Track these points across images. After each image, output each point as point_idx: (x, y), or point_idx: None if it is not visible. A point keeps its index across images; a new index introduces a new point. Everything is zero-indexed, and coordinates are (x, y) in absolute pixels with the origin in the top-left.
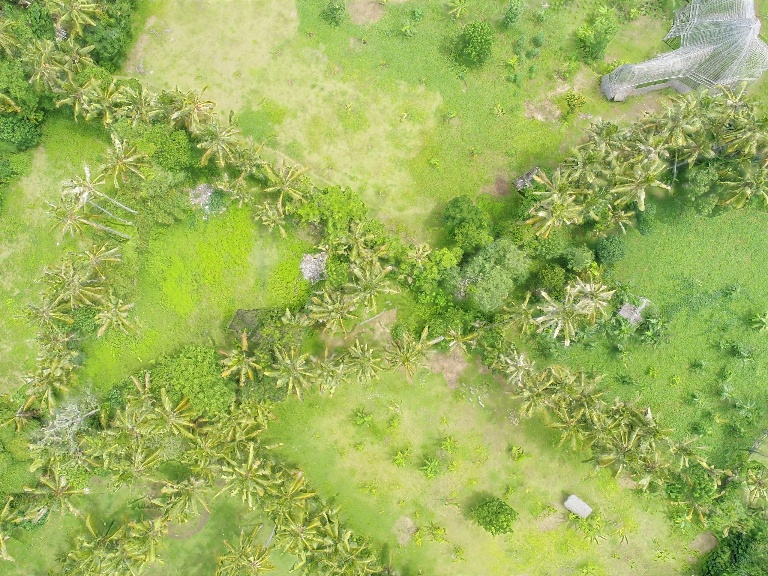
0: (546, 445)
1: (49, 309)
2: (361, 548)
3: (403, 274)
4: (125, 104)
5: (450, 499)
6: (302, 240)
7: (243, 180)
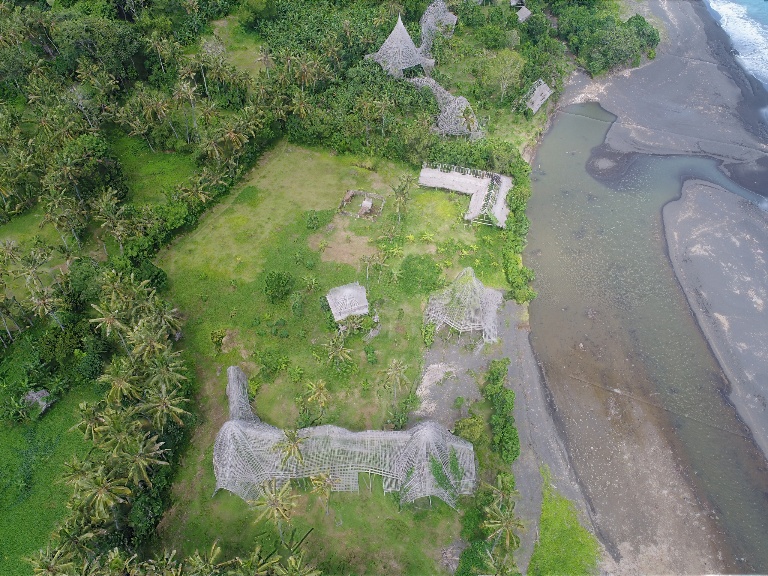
0: None
1: None
2: None
3: None
4: None
5: None
6: None
7: (204, 176)
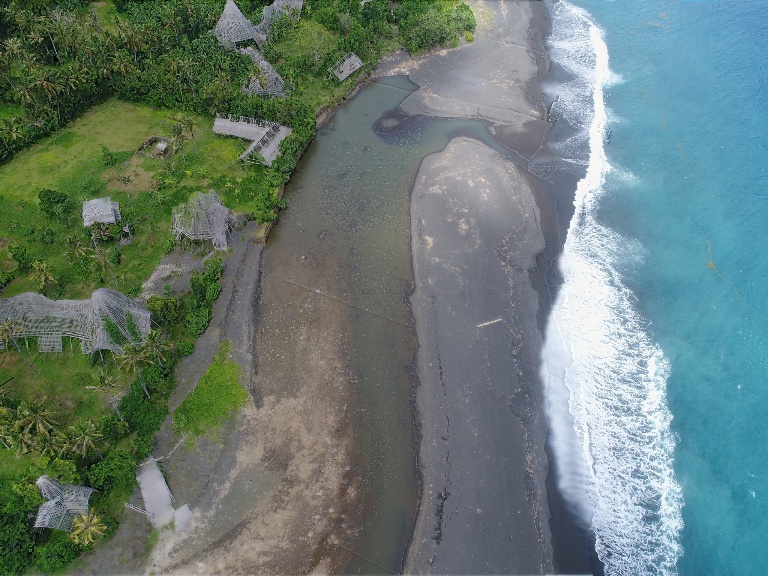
0: None
1: None
2: None
3: None
4: None
5: None
6: None
7: None
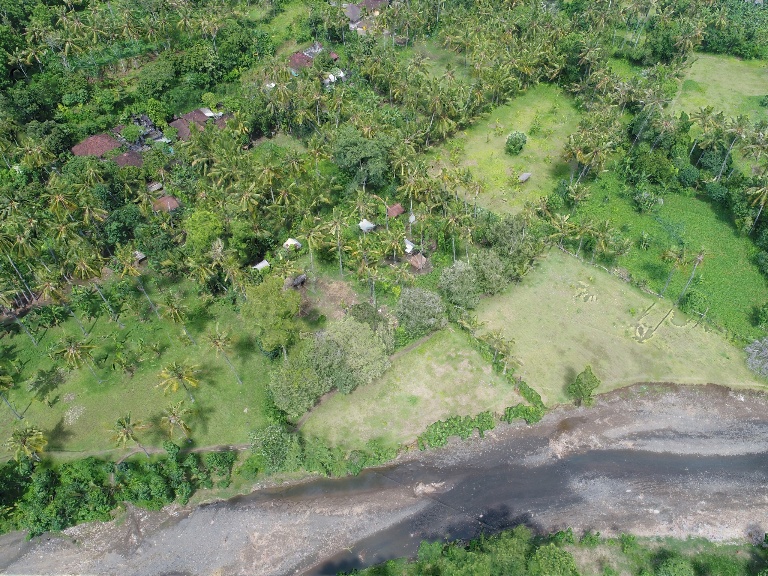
0: (556, 172)
1: None
2: None
3: None
4: None
5: None
6: None
7: None
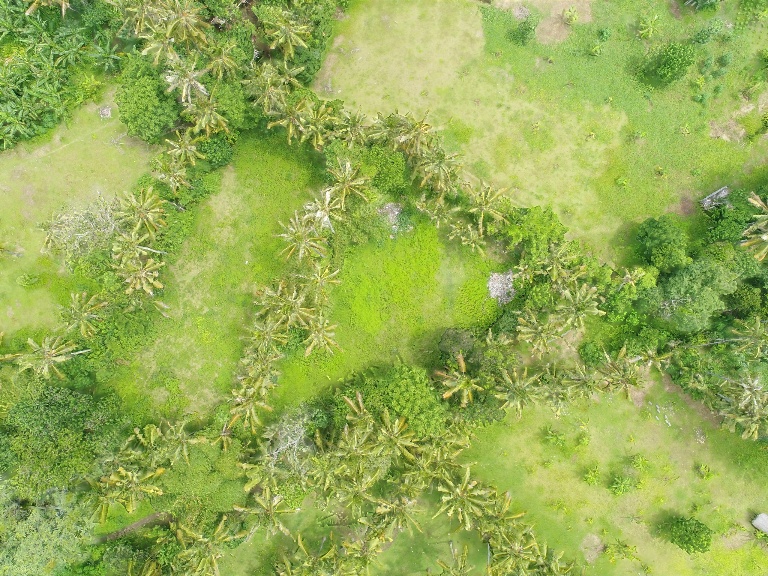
0: (732, 463)
1: (271, 330)
2: (570, 567)
3: (595, 293)
4: (341, 126)
5: (637, 517)
6: (489, 259)
7: (442, 200)
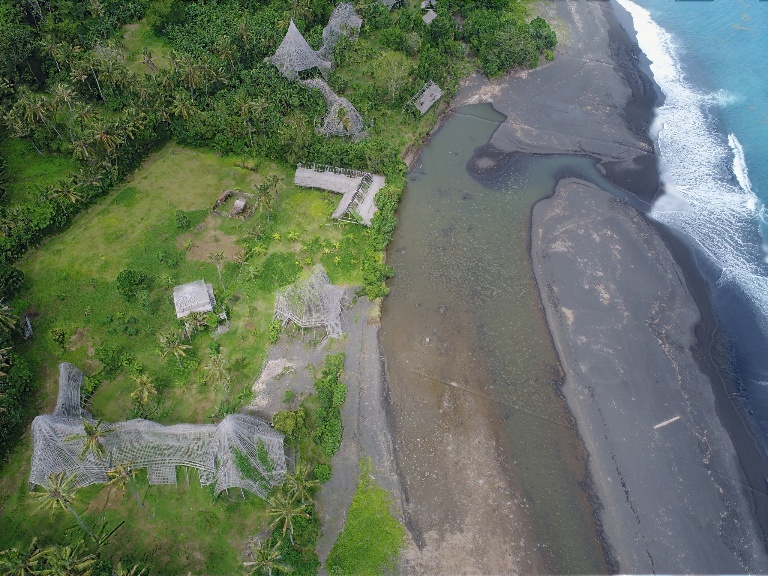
0: None
1: None
2: None
3: None
4: None
5: None
6: None
7: None
